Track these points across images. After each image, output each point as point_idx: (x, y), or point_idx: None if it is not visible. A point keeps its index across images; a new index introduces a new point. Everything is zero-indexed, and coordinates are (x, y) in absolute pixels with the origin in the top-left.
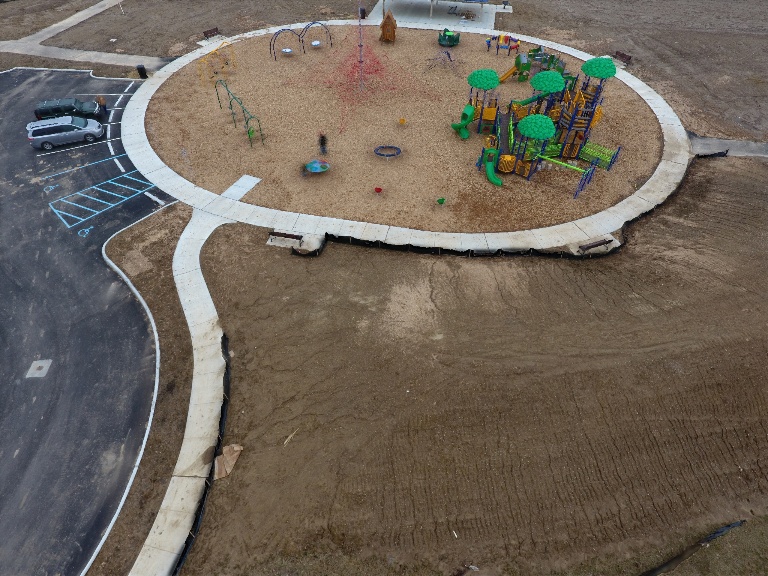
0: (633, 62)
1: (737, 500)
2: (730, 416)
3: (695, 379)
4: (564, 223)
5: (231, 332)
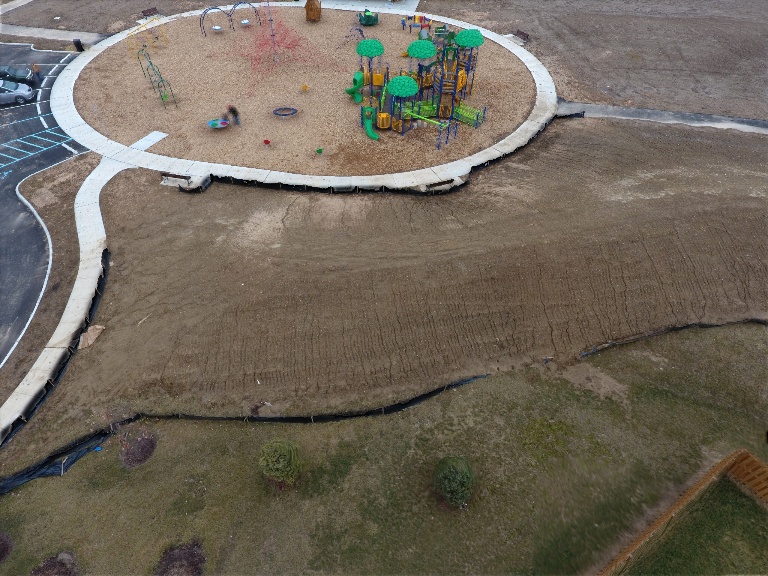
0: (532, 40)
1: (489, 361)
2: (498, 302)
3: (474, 274)
4: (423, 169)
5: (114, 248)
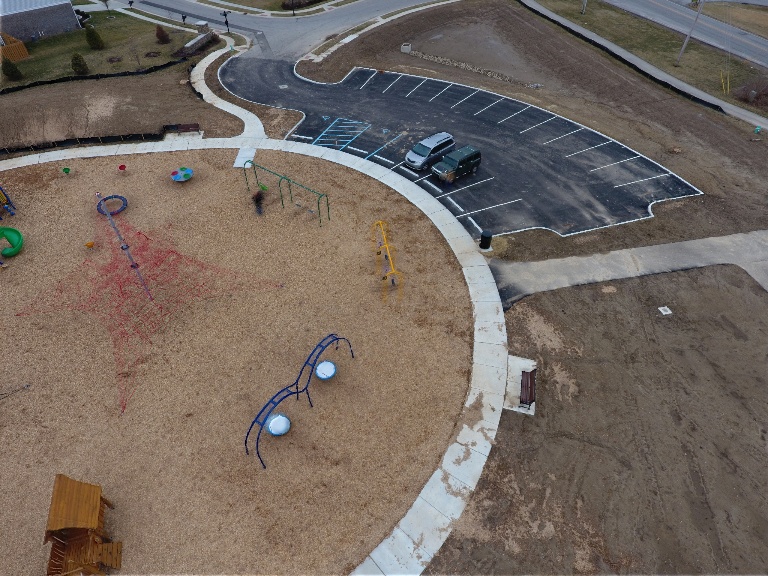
0: None
1: None
2: None
3: None
4: None
5: (203, 102)
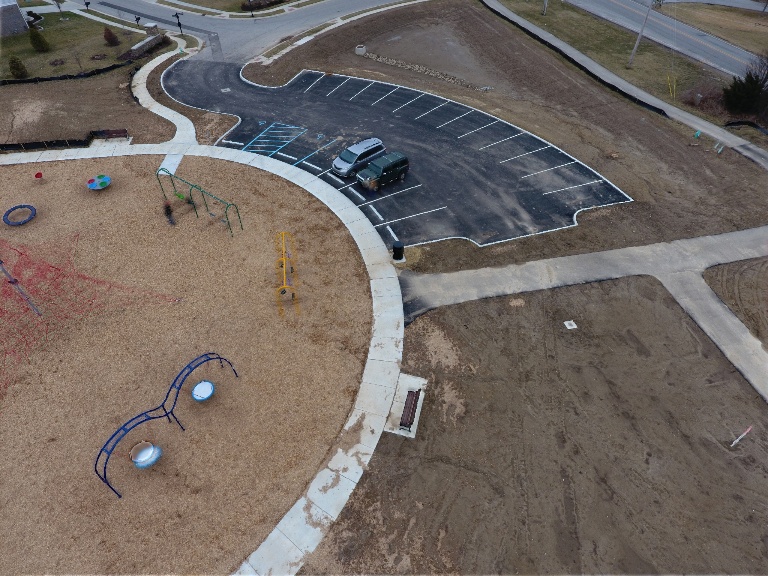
0: None
1: None
2: None
3: None
4: None
5: None
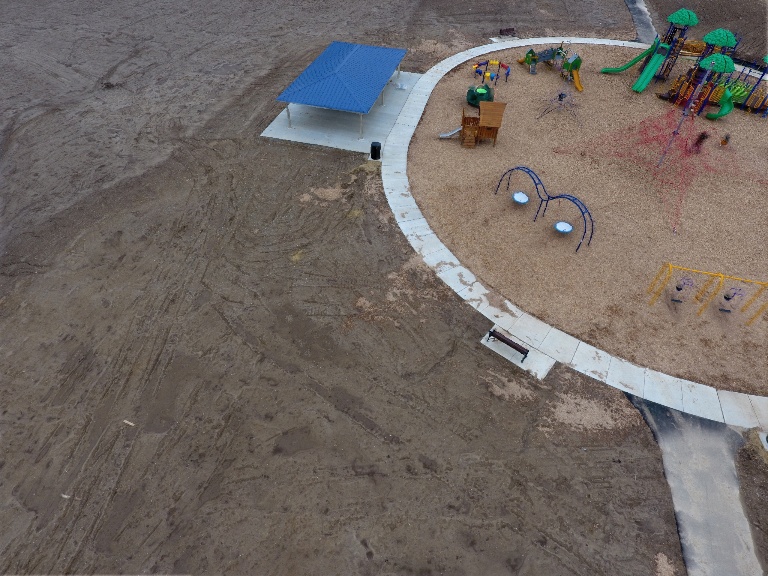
0: None
1: None
2: None
3: None
4: None
5: None
